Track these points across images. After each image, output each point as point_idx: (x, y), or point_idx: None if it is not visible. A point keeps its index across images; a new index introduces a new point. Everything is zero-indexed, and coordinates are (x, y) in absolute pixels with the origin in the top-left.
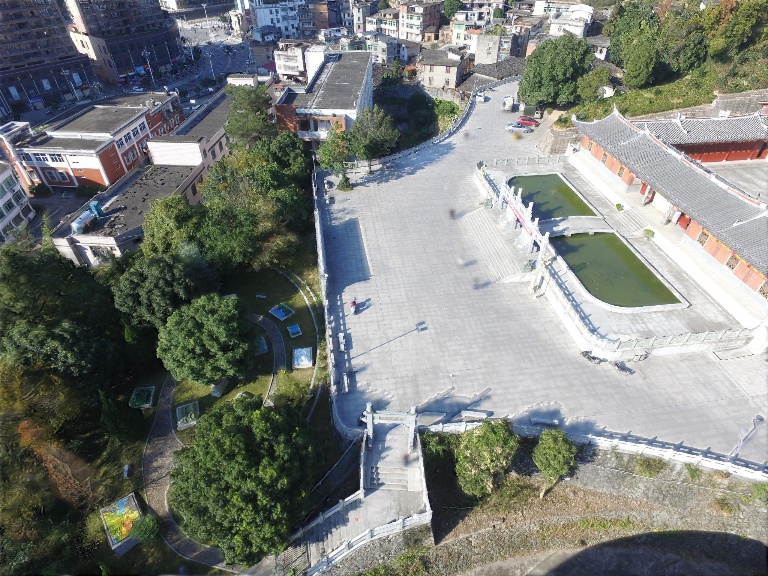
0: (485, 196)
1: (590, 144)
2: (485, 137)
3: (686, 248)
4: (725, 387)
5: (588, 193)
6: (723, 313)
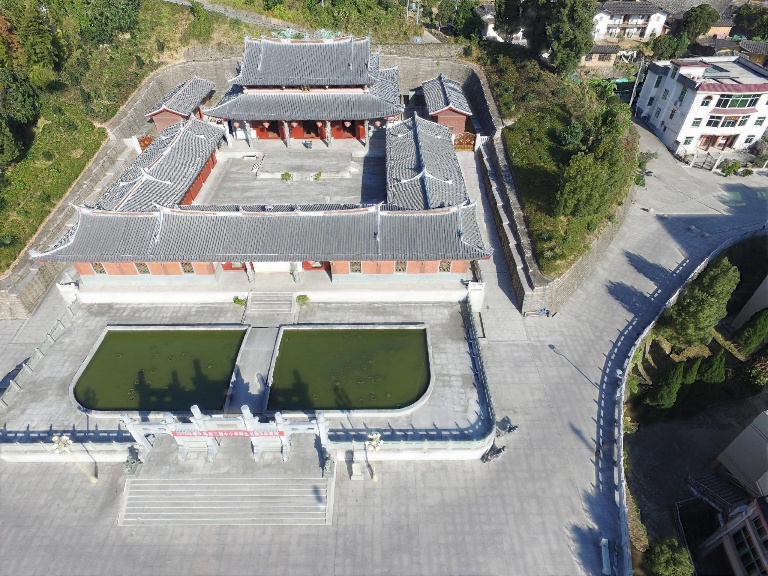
0: (82, 459)
1: (96, 266)
2: None
3: (346, 284)
4: (519, 352)
5: (179, 316)
6: (437, 306)
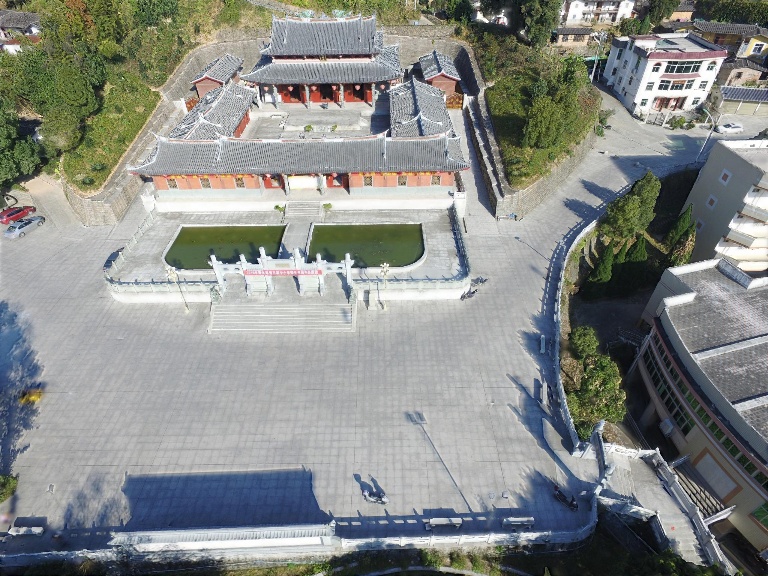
0: (177, 299)
1: (170, 181)
2: (8, 263)
3: (360, 196)
4: (492, 241)
5: (234, 219)
6: (430, 211)
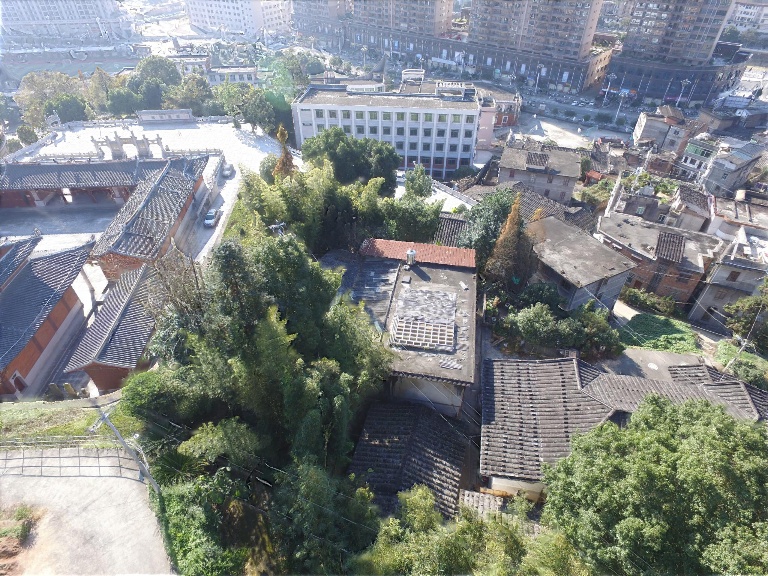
0: None
1: None
2: None
3: None
4: None
5: None
6: None
